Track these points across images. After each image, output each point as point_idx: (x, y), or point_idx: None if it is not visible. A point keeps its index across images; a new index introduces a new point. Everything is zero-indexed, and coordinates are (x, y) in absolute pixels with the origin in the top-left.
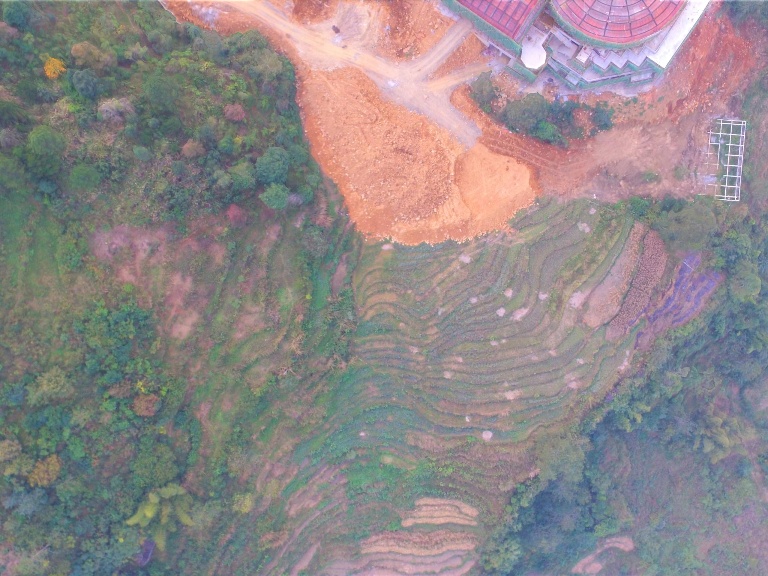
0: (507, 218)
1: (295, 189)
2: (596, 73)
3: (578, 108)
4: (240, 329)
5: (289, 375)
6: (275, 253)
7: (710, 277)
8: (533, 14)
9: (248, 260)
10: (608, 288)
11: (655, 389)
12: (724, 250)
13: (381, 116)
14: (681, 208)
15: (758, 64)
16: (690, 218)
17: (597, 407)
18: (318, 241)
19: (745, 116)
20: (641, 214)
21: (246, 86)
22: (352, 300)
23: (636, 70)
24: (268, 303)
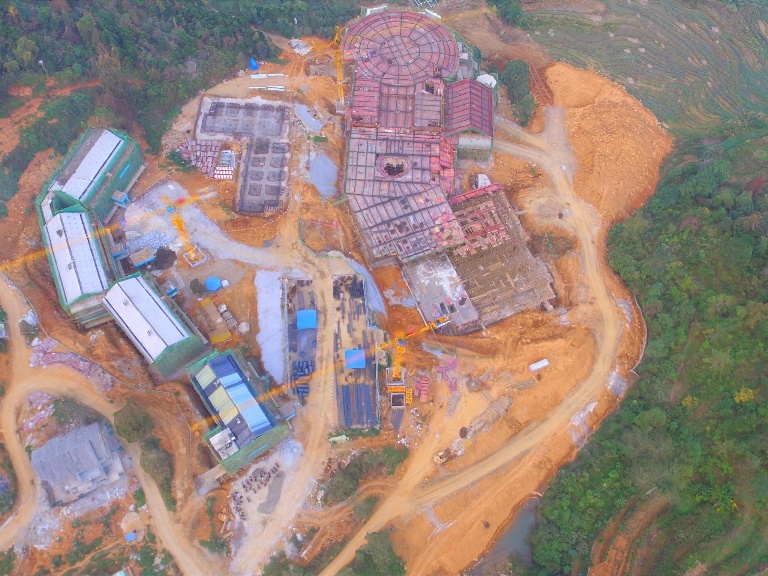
0: None
1: None
2: None
3: None
4: None
5: None
6: None
7: None
8: None
9: (766, 182)
10: (575, 7)
11: None
12: None
13: (597, 154)
14: None
15: (368, 4)
16: None
17: None
18: None
19: None
20: None
21: None
22: None
23: None
24: None
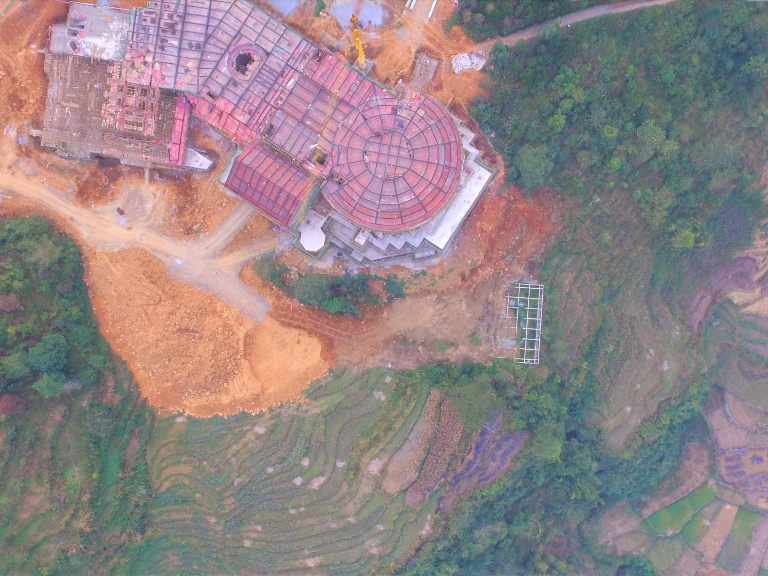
0: (301, 389)
1: (76, 372)
2: (378, 252)
3: (371, 279)
4: (25, 510)
5: (78, 553)
6: (61, 433)
7: (515, 436)
8: (307, 201)
9: (31, 442)
10: (406, 454)
11: (463, 548)
12: (524, 413)
13: (165, 297)
14: (481, 372)
15: (555, 228)
16: (468, 398)
17: (400, 571)
18: (102, 422)
19: (545, 278)
20: (437, 381)
21: (23, 274)
22: (145, 473)
23: (416, 250)
24: (53, 483)
